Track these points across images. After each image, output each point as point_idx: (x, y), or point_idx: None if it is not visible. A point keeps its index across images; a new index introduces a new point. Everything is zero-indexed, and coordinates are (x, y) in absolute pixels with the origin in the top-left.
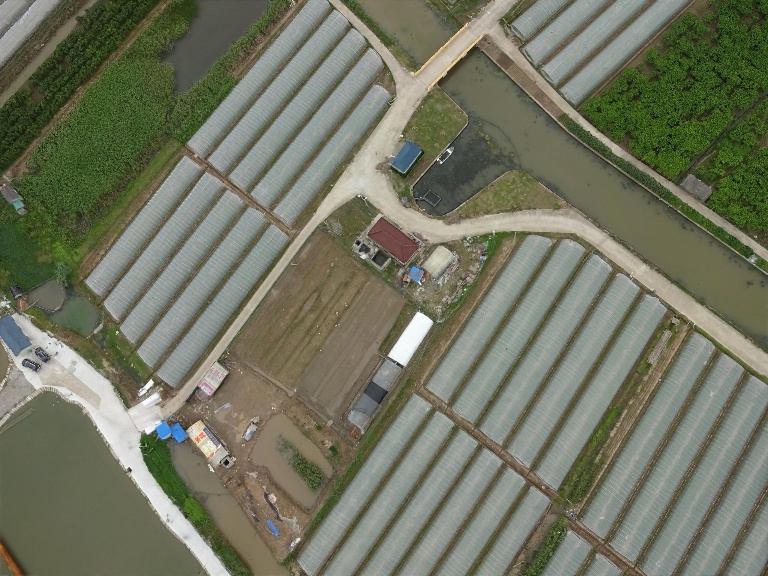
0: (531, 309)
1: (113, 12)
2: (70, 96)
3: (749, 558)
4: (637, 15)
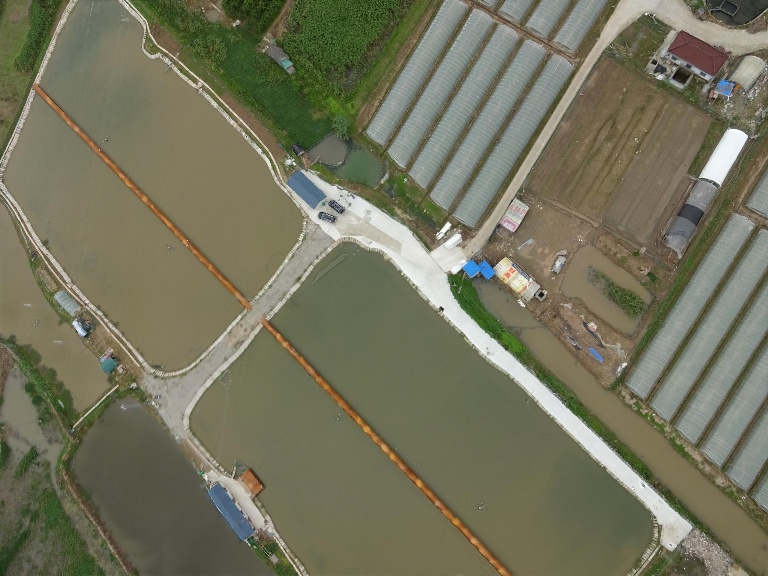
0: None
1: None
2: None
3: None
4: None
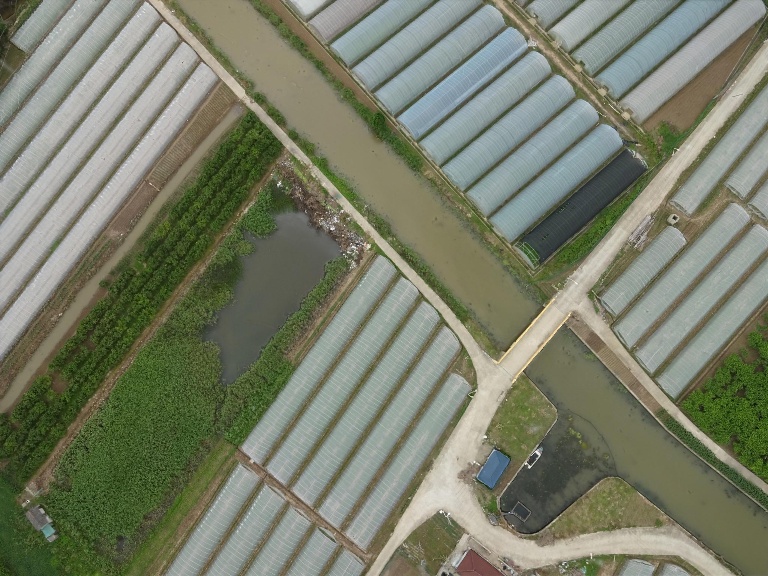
0: None
1: (144, 277)
2: (99, 384)
3: None
4: (737, 286)
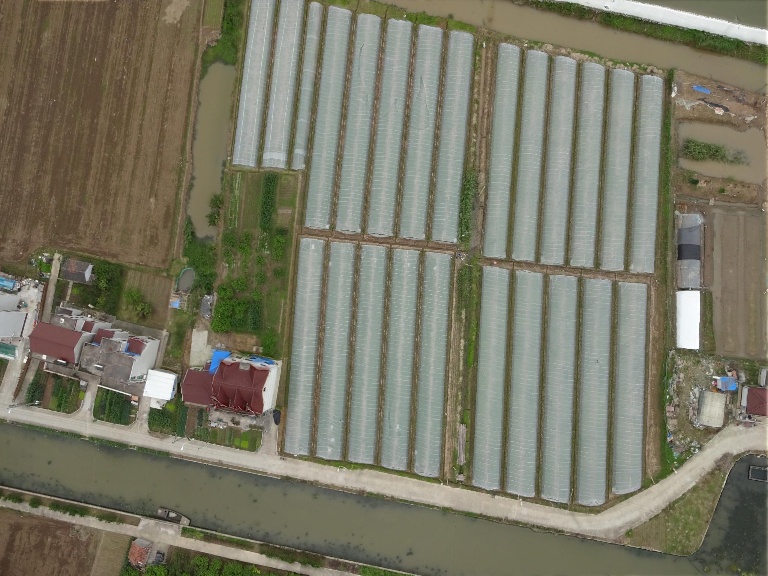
0: (597, 413)
1: None
2: None
3: (309, 307)
4: None
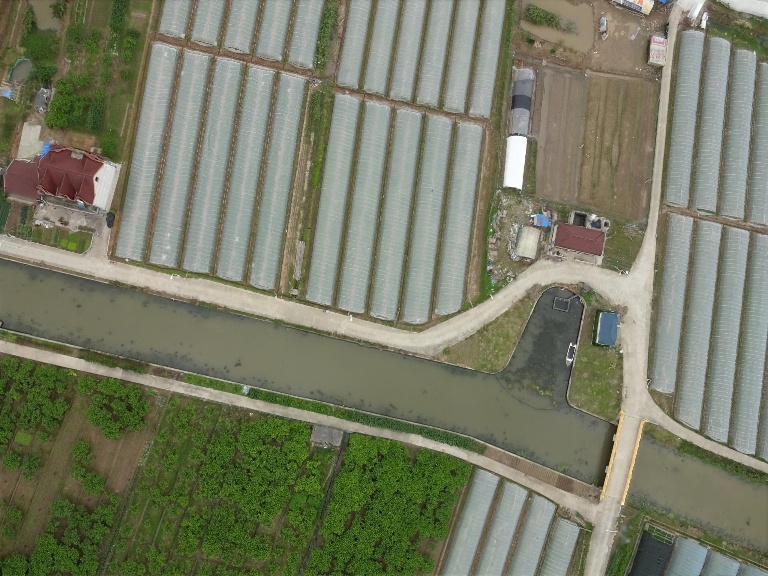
0: (428, 238)
1: None
2: None
3: (156, 114)
4: None
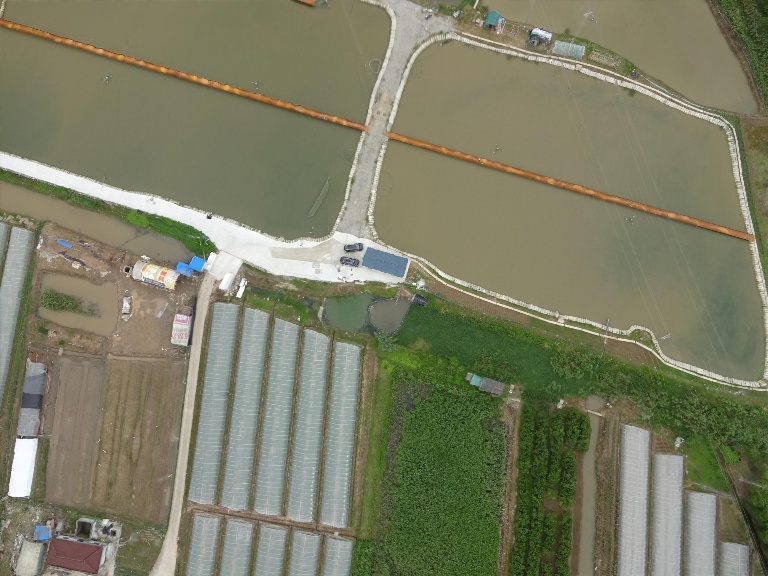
0: None
1: None
2: None
3: None
4: None
